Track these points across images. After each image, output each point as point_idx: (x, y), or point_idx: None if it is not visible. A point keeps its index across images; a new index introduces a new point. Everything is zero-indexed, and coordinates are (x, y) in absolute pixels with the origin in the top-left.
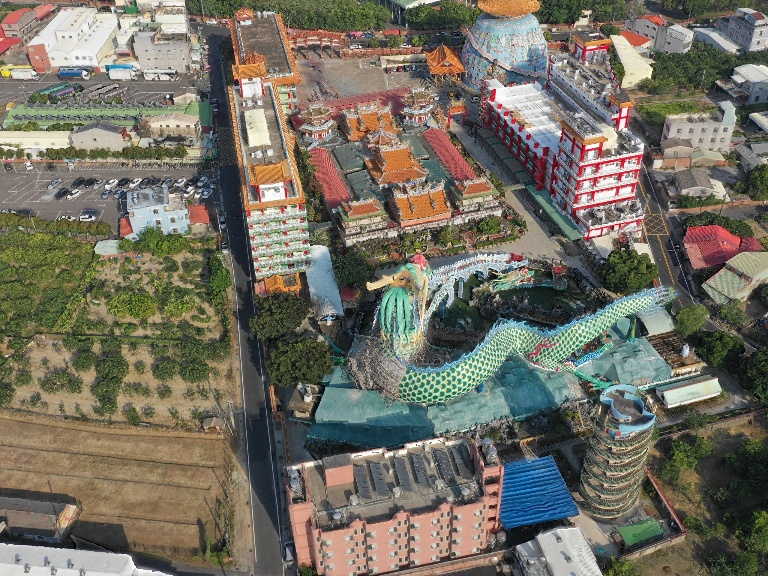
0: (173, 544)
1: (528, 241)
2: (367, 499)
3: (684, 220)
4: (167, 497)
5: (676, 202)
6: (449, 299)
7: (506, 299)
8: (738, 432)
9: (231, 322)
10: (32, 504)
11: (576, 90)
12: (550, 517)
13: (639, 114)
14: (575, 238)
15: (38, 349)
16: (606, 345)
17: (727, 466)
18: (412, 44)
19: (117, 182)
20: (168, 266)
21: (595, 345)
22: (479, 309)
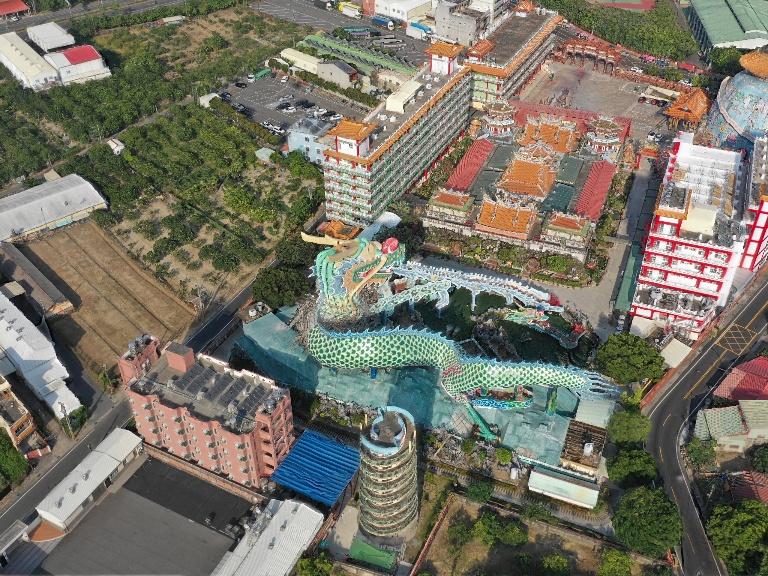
0: (97, 360)
1: (586, 294)
2: (179, 388)
3: None
4: (125, 331)
5: None
6: (441, 300)
7: (511, 331)
8: (572, 549)
9: None
10: (53, 290)
11: None
12: (310, 493)
13: None
14: (620, 308)
15: (161, 202)
16: (517, 402)
17: (515, 563)
18: None
19: (326, 112)
20: (293, 185)
21: (511, 397)
22: None
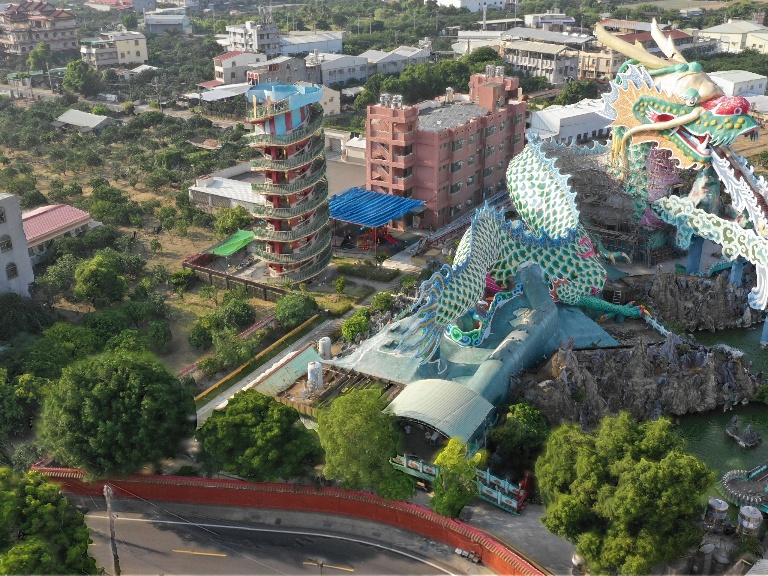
0: None
1: None
2: None
3: None
4: None
5: None
6: None
7: None
8: None
9: None
10: None
11: None
12: None
13: None
14: None
15: None
16: None
17: None
18: None
19: None
20: None
21: None
22: None
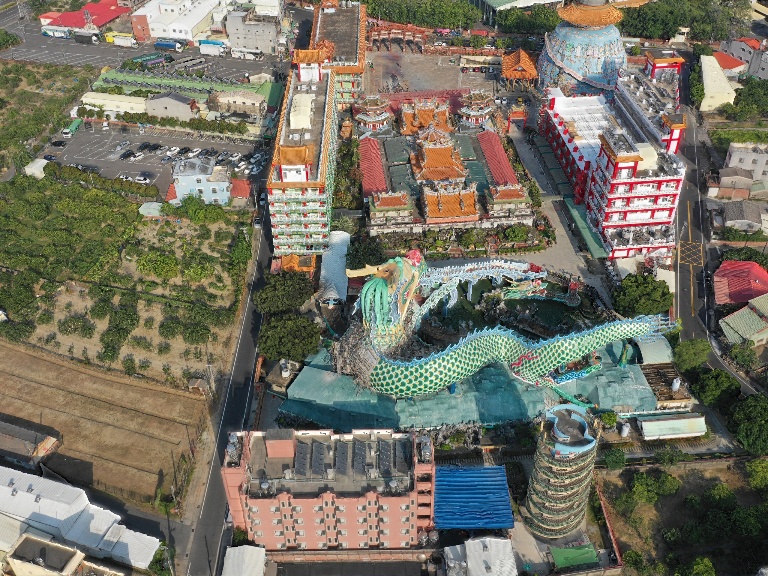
0: (132, 488)
1: (553, 253)
2: (301, 475)
3: (722, 252)
4: (139, 445)
5: (719, 233)
6: (451, 299)
7: None
8: (713, 476)
9: (243, 293)
10: (19, 431)
11: (636, 107)
12: (484, 525)
13: (710, 139)
14: (599, 256)
15: (66, 293)
16: (593, 366)
17: (688, 507)
18: (497, 46)
19: (179, 150)
20: (202, 233)
21: (583, 365)
22: (484, 314)
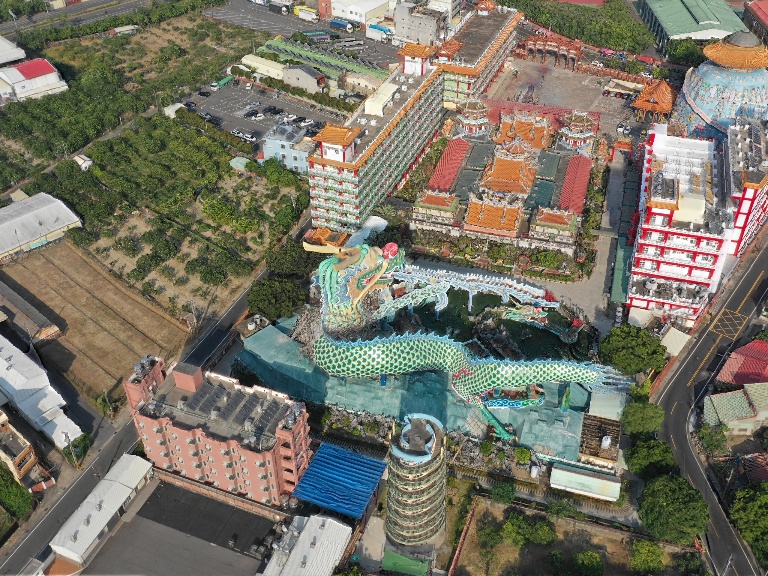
0: (92, 385)
1: (579, 288)
2: (191, 409)
3: None
4: (117, 353)
5: None
6: (439, 303)
7: (510, 329)
8: (601, 543)
9: None
10: (36, 314)
11: None
12: (336, 507)
13: None
14: (616, 300)
15: (137, 218)
16: (530, 400)
17: (548, 562)
18: None
19: (296, 118)
20: (271, 194)
21: (523, 396)
22: None
